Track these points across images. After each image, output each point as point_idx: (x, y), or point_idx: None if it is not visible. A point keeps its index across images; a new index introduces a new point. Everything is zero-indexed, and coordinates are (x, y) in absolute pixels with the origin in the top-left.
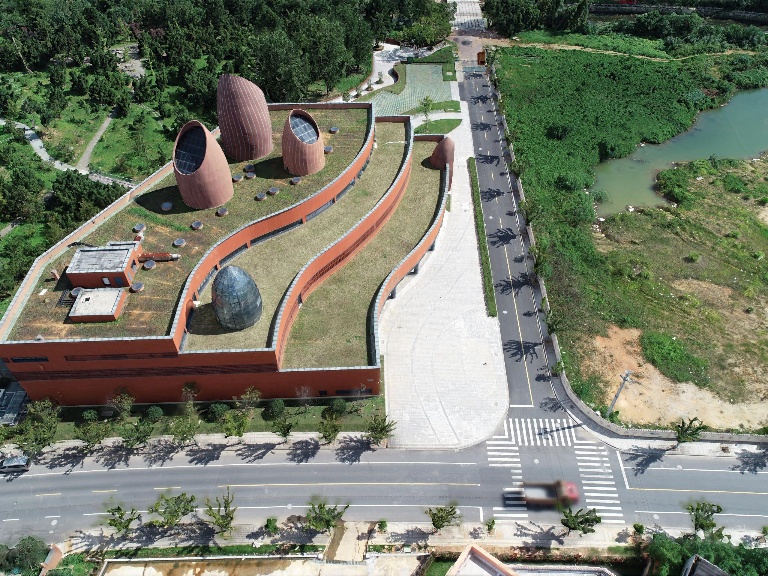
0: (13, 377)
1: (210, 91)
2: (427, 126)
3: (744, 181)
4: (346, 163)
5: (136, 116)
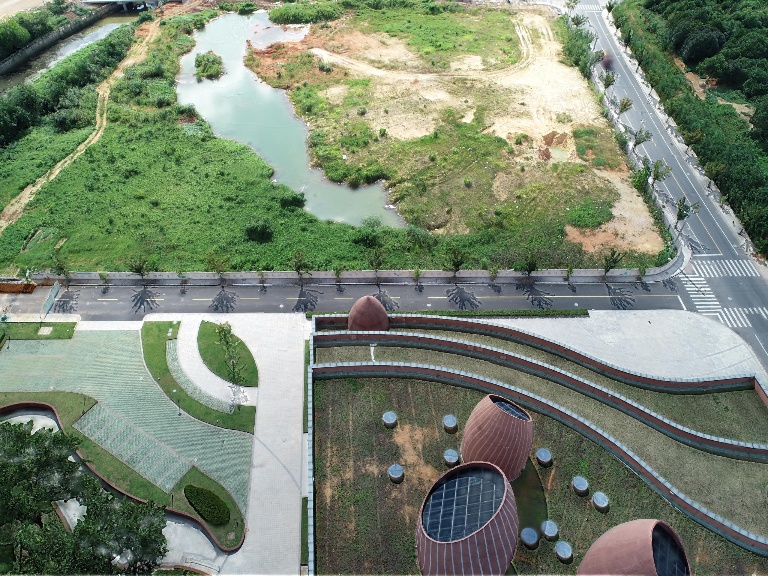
0: None
1: None
2: None
3: (350, 135)
4: (478, 397)
5: None
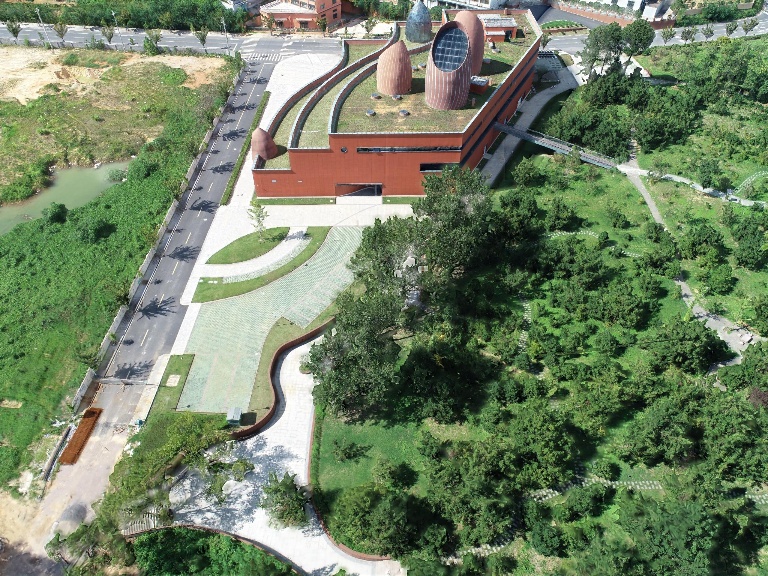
0: (545, 74)
1: (555, 249)
2: (260, 234)
3: None
4: (359, 88)
5: (625, 218)
